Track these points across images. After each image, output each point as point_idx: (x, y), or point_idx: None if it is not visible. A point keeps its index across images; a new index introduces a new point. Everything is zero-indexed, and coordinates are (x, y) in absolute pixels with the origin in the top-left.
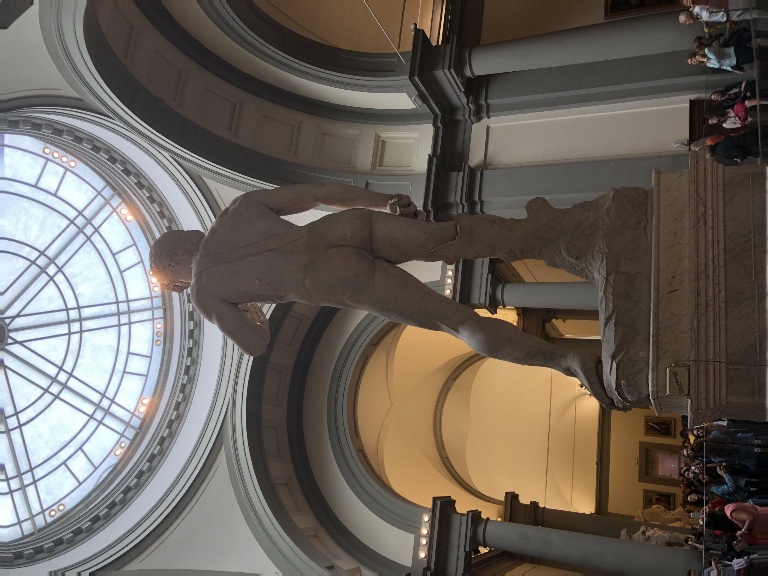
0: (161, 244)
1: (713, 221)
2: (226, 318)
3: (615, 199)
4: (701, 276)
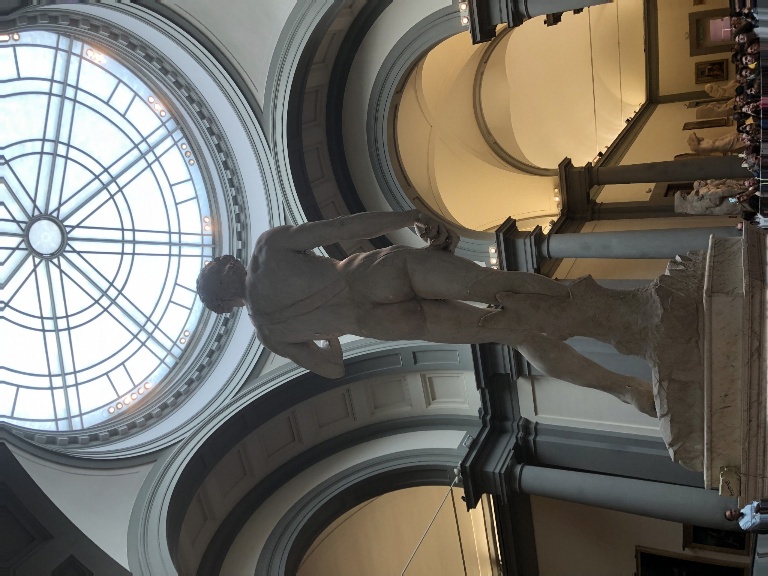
0: (206, 289)
1: (767, 352)
2: (300, 360)
3: (664, 320)
4: (753, 405)
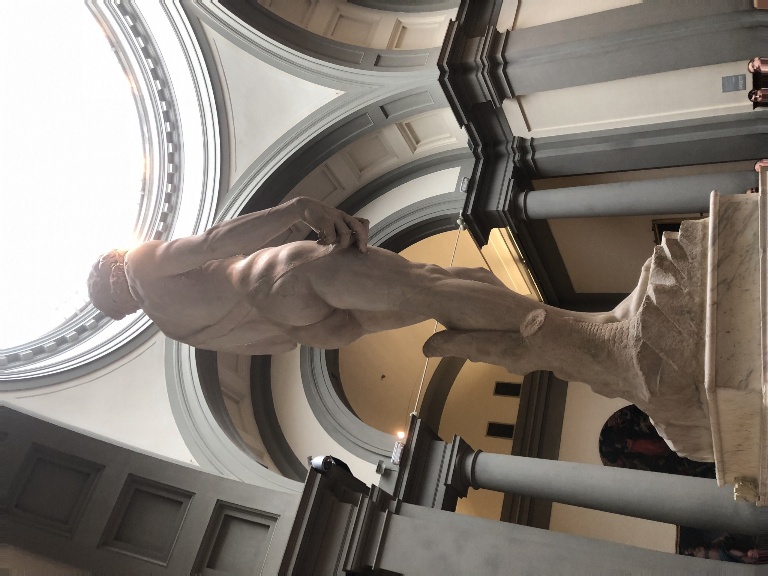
0: (103, 308)
1: None
2: None
3: (653, 402)
4: None
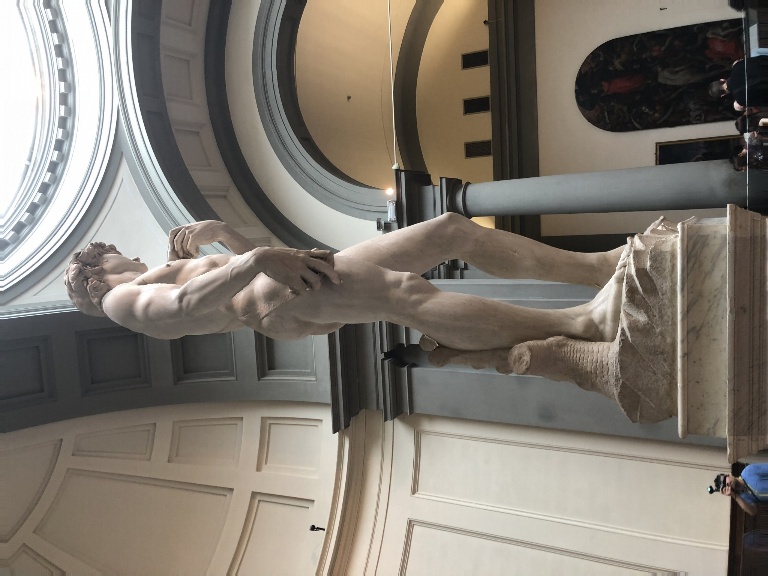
0: None
1: None
2: None
3: None
4: None
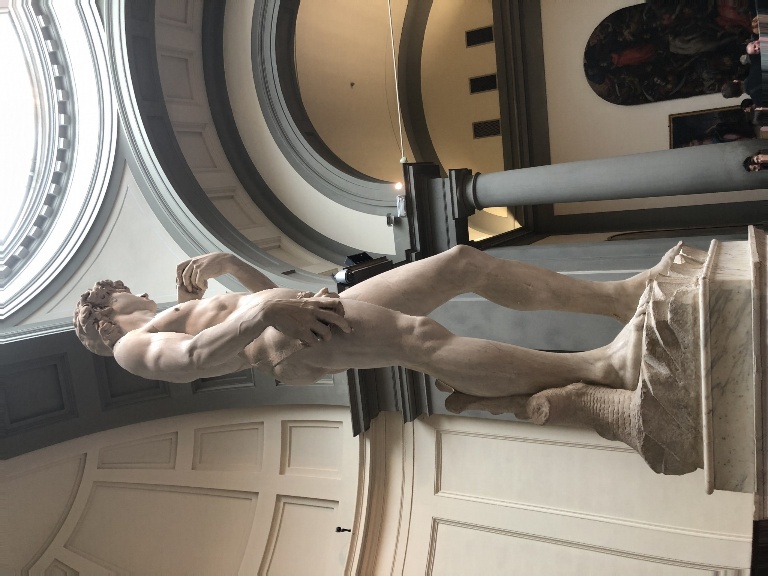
0: None
1: None
2: None
3: None
4: None
